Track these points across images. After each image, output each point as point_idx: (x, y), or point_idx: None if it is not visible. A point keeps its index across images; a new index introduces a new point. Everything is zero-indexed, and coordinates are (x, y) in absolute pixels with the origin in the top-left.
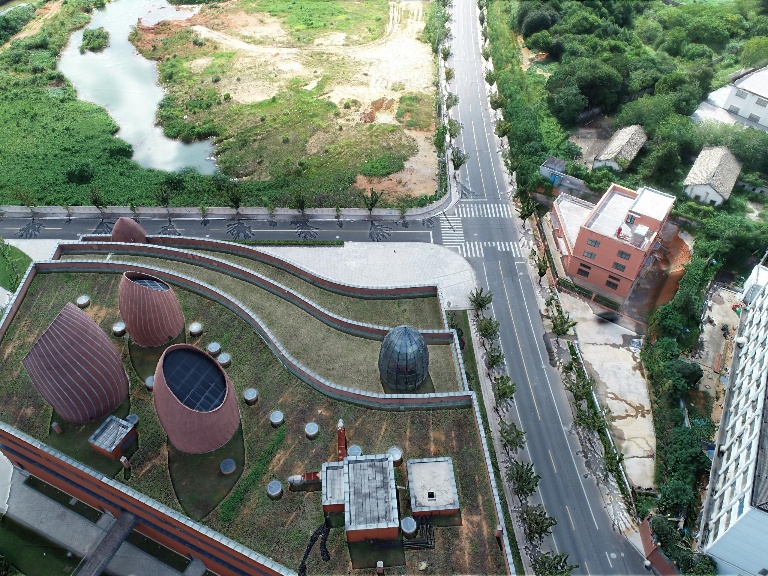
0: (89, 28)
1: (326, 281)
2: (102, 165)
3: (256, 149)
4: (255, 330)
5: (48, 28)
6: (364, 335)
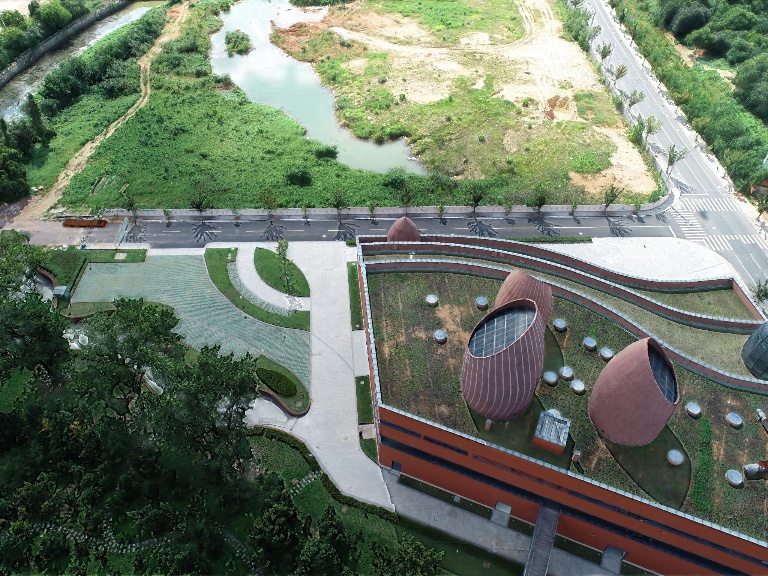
0: (230, 31)
1: (622, 276)
2: (313, 167)
3: (456, 148)
4: (616, 324)
5: (191, 31)
6: (707, 327)
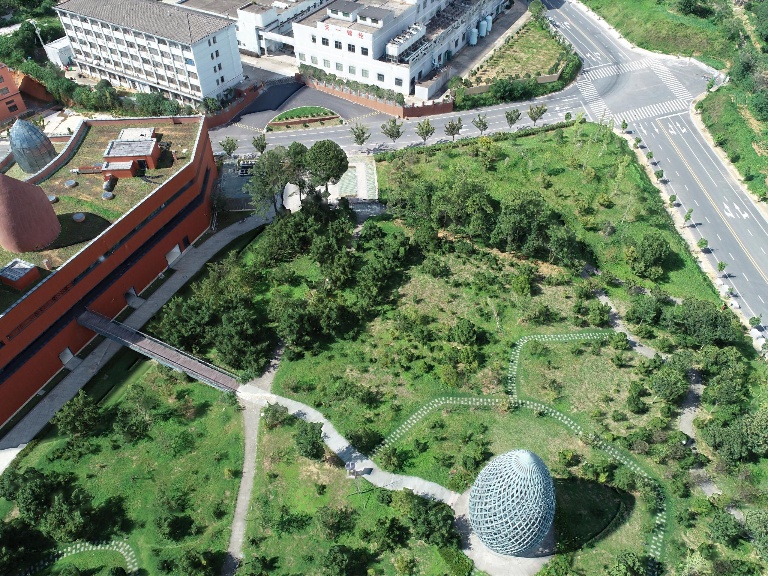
0: None
1: None
2: None
3: None
4: None
5: None
6: None
